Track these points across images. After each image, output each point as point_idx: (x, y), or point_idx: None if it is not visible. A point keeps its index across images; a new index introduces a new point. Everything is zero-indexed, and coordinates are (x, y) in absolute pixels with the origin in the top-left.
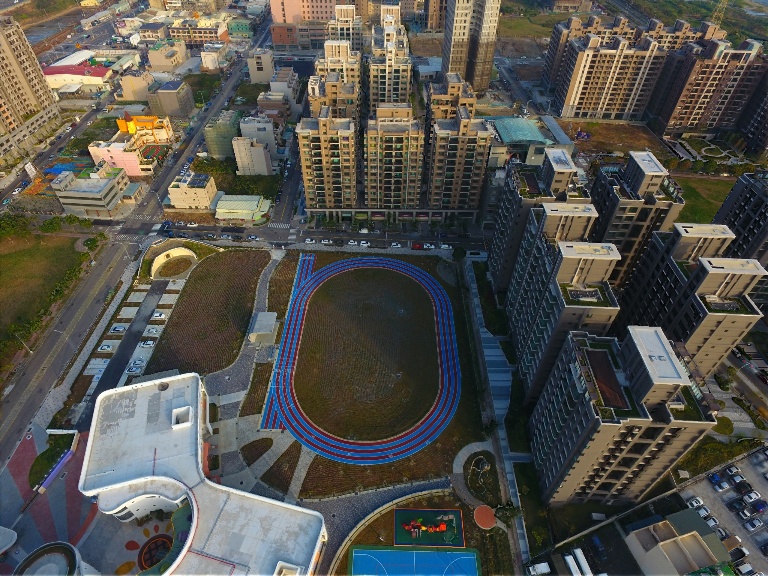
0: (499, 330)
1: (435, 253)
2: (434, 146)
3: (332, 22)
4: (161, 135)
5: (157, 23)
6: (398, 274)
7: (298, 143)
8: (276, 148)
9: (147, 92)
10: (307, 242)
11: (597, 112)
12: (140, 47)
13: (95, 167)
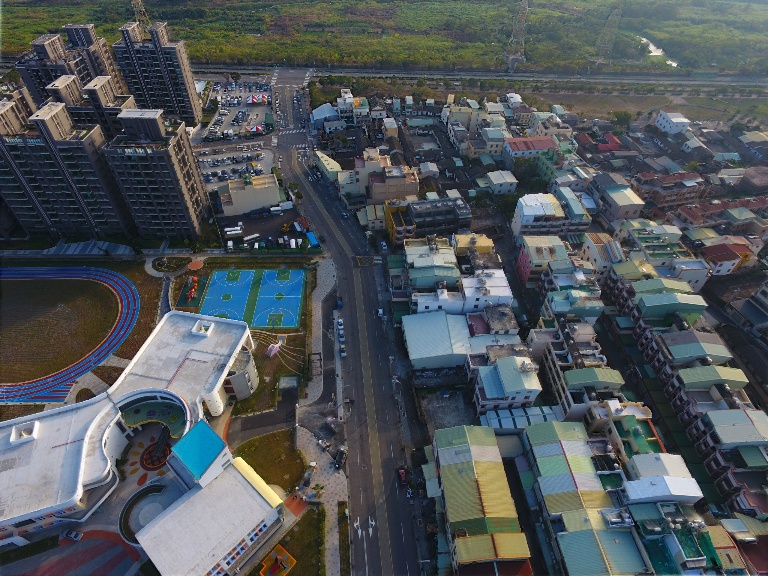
0: (52, 242)
1: None
2: None
3: None
4: None
5: None
6: None
7: None
8: None
9: None
10: None
11: None
12: None
13: None
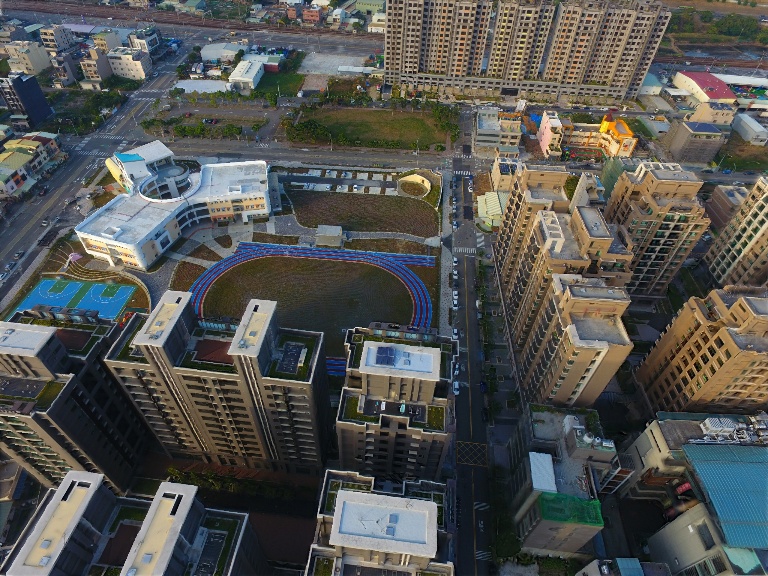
0: None
1: None
2: None
3: None
4: (612, 148)
5: None
6: None
7: None
8: None
9: None
10: None
11: None
12: None
13: None
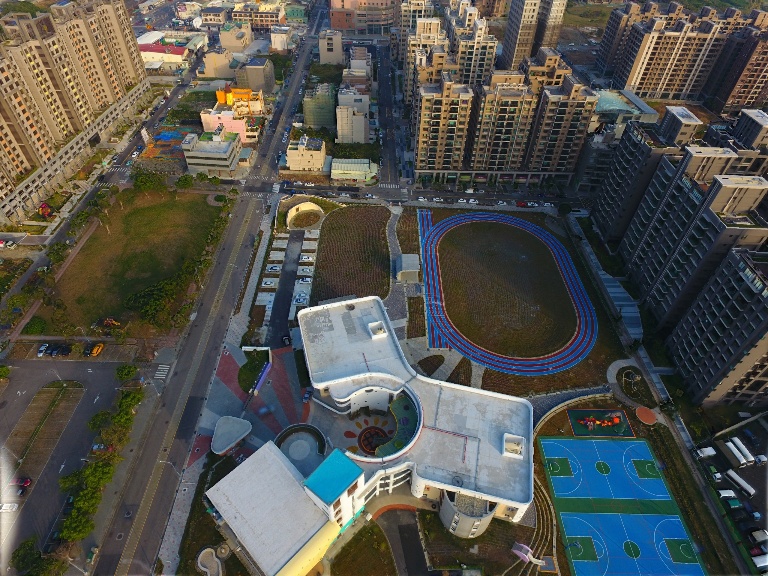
0: (617, 272)
1: (540, 210)
2: (544, 110)
3: (404, 5)
4: (256, 107)
5: (216, 7)
6: (511, 227)
7: (421, 106)
8: (368, 119)
9: (228, 69)
10: (420, 200)
11: (656, 92)
12: (202, 30)
13: (216, 130)
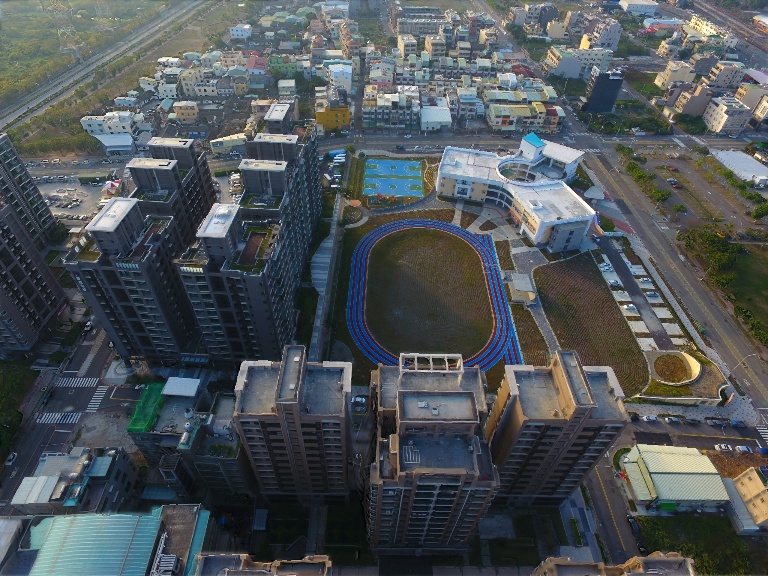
0: None
1: None
2: None
3: None
4: None
5: None
6: None
7: None
8: None
9: None
10: None
11: None
12: None
13: None
